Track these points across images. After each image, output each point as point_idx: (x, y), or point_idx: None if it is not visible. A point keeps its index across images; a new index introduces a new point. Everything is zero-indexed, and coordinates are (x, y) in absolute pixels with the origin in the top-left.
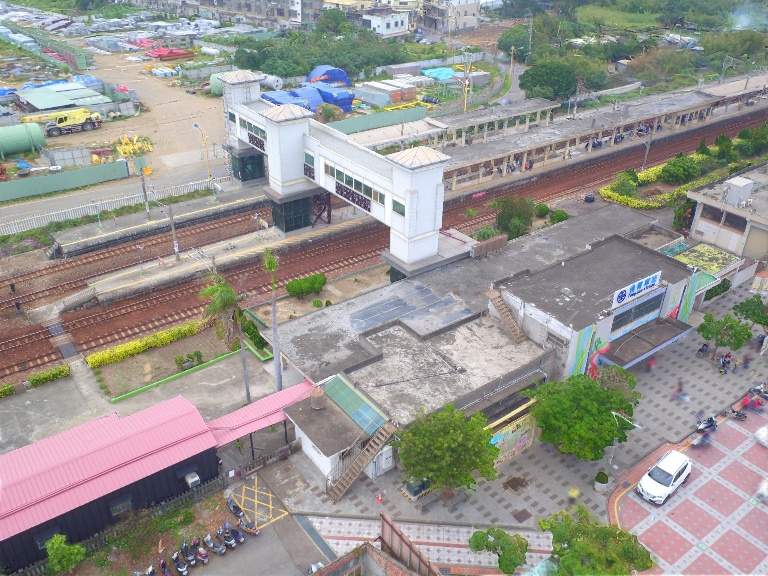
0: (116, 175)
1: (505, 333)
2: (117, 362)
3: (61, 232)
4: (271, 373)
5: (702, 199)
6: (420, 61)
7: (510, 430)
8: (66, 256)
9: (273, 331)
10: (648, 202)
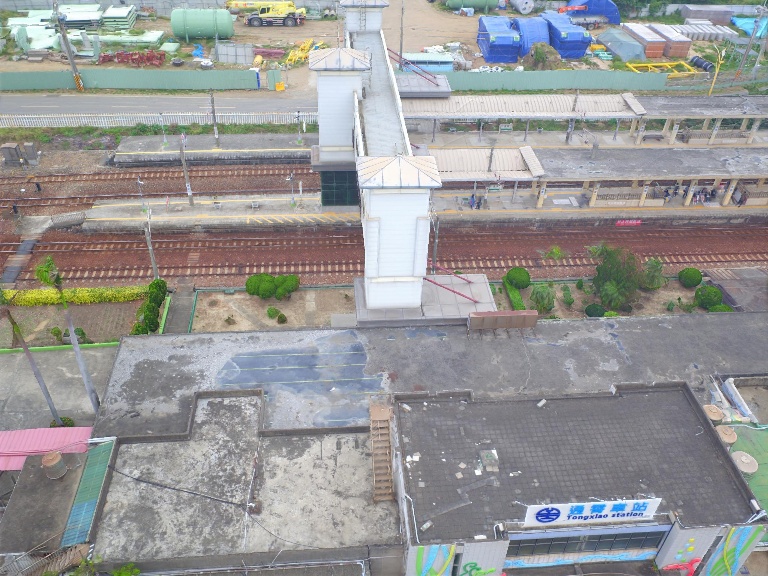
0: (245, 85)
1: None
2: (27, 306)
3: (132, 138)
4: None
5: None
6: (739, 5)
7: None
8: (117, 165)
9: (76, 353)
10: None
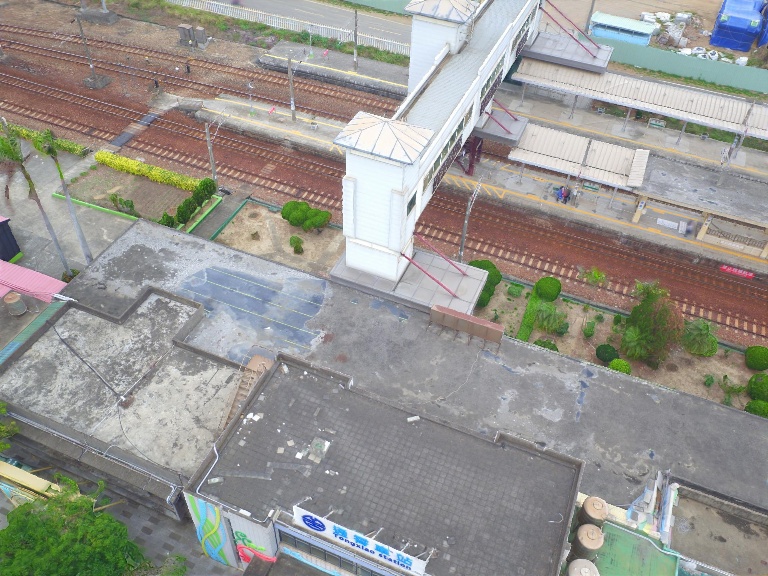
0: None
1: None
2: (115, 170)
3: (288, 43)
4: None
5: None
6: None
7: (32, 497)
8: (263, 66)
9: None
10: None
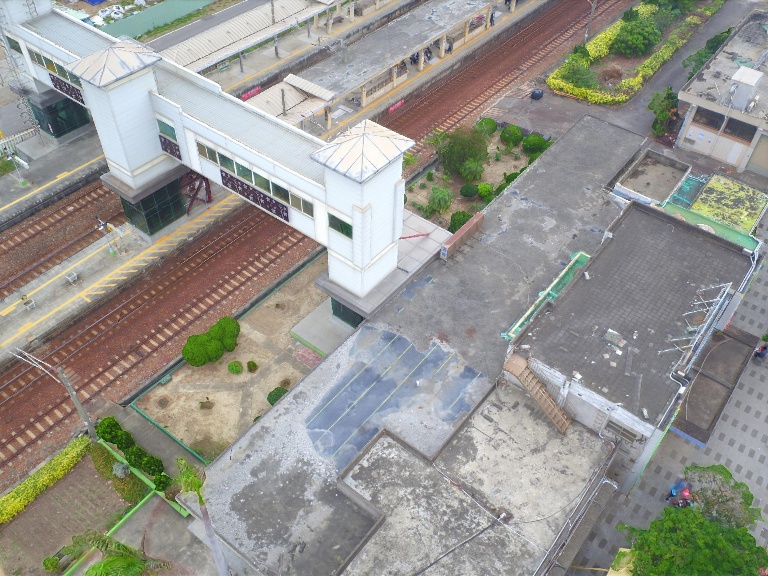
0: None
1: (539, 415)
2: None
3: None
4: (206, 542)
5: (699, 102)
6: None
7: None
8: None
9: None
10: (613, 95)
